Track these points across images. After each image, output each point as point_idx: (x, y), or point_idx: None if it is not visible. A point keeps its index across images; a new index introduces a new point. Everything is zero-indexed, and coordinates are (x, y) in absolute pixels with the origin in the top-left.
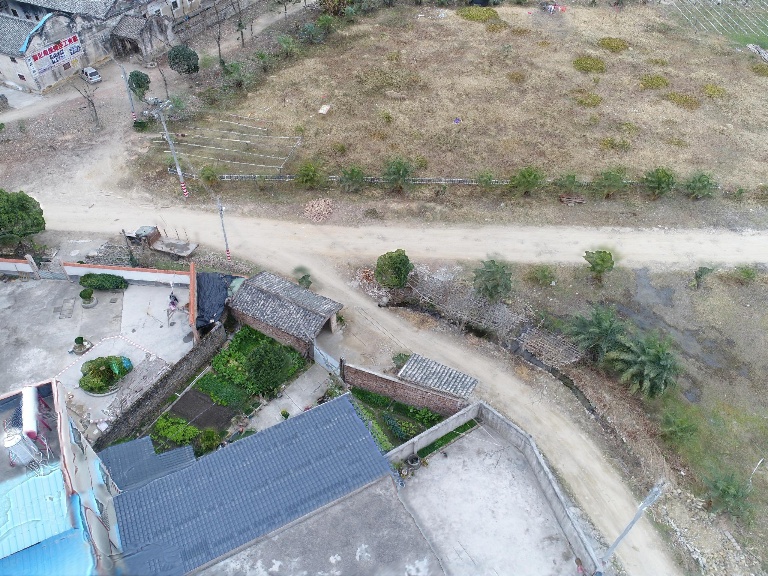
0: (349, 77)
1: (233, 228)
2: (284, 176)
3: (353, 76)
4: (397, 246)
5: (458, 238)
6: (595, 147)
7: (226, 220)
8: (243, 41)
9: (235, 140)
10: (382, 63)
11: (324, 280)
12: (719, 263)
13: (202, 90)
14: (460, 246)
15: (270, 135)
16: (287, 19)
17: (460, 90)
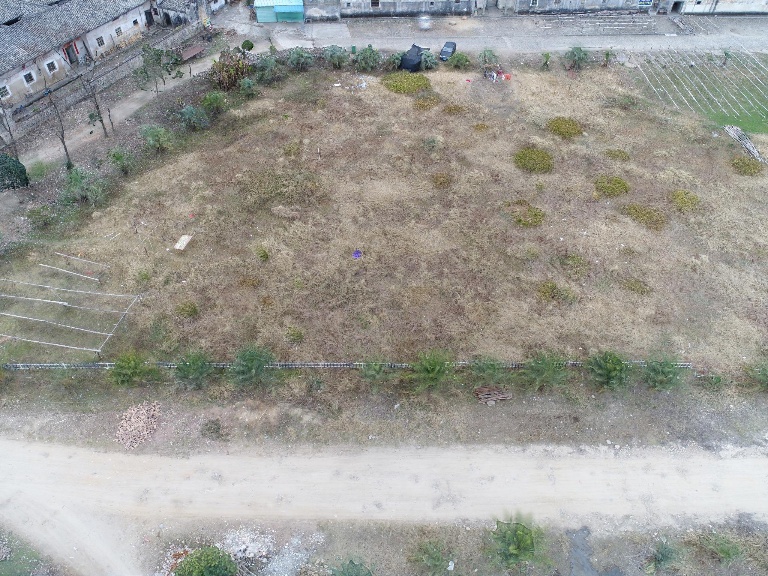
0: (230, 183)
1: (7, 464)
2: (102, 364)
3: (235, 182)
4: (237, 494)
5: (327, 474)
6: (531, 296)
7: (1, 448)
8: (105, 130)
9: (48, 301)
10: (276, 160)
11: (114, 572)
12: (688, 516)
13: (36, 206)
14: (327, 492)
15: (105, 284)
16: (172, 92)
17: (368, 203)
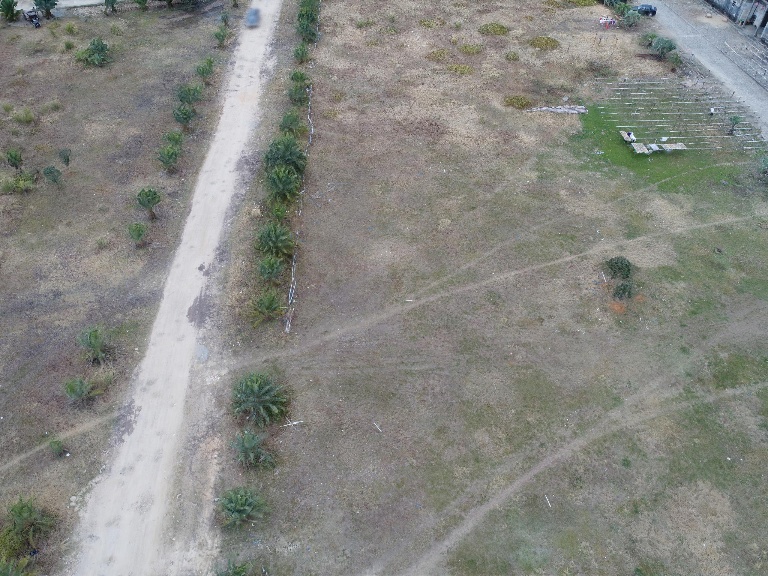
0: None
1: None
2: None
3: None
4: None
5: None
6: None
7: None
8: None
9: None
10: None
11: None
12: None
13: None
14: None
15: None
16: None
17: None
